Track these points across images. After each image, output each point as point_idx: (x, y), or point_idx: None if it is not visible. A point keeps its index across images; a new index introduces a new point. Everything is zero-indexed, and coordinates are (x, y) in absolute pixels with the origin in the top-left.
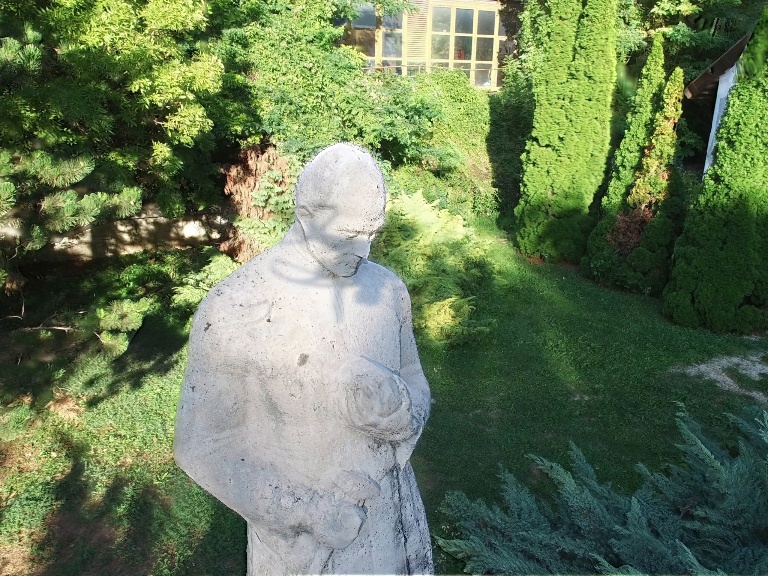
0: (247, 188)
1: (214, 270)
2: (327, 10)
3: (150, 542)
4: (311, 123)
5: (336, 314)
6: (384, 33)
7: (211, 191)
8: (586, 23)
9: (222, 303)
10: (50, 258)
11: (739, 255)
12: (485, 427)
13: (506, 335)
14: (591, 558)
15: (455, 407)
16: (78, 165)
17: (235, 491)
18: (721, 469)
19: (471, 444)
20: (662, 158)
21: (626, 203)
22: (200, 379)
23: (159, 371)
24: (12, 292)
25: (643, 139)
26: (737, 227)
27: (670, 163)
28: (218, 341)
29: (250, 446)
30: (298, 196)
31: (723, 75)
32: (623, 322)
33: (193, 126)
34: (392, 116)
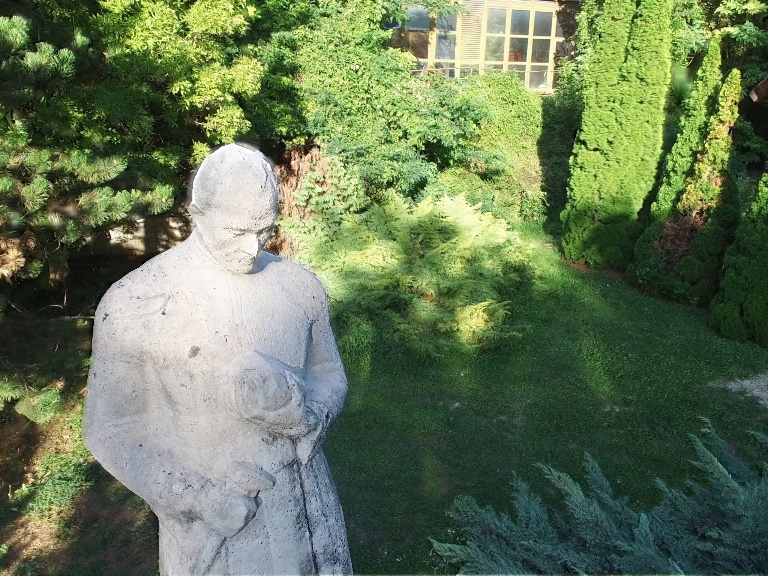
0: (289, 188)
1: None
2: (377, 13)
3: None
4: (355, 124)
5: (232, 308)
6: (438, 35)
7: None
8: (640, 23)
9: (120, 294)
10: (106, 251)
11: None
12: (508, 433)
13: (541, 341)
14: (572, 571)
15: (479, 412)
16: (112, 163)
17: (131, 474)
18: (739, 489)
19: (491, 450)
20: (715, 163)
21: (676, 209)
22: (100, 365)
23: None
24: (55, 282)
25: (696, 143)
26: None
27: (724, 168)
28: (114, 330)
29: (150, 432)
30: None
31: None
32: (666, 333)
33: (231, 126)
34: (437, 118)
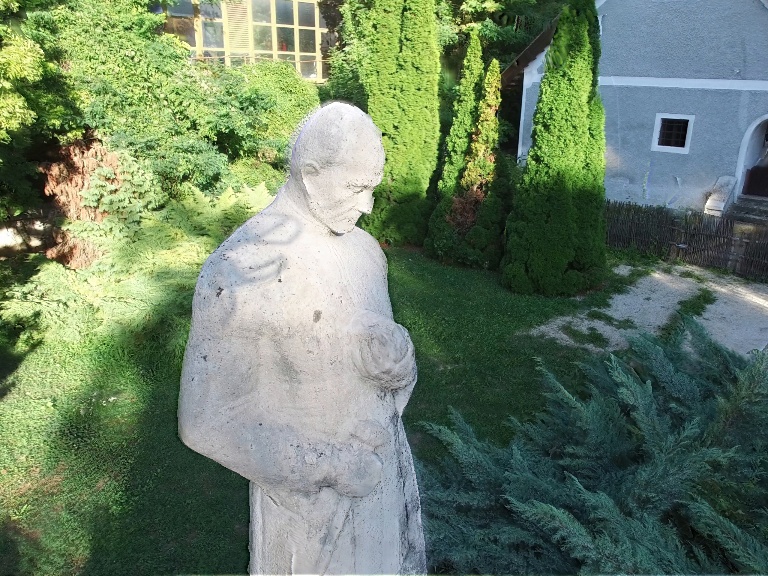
0: (74, 187)
1: (44, 280)
2: None
3: None
4: (140, 115)
5: (339, 269)
6: (203, 22)
7: (27, 193)
8: (409, 16)
9: (231, 265)
10: None
11: (561, 226)
12: None
13: None
14: (502, 498)
15: None
16: None
17: (257, 455)
18: (581, 409)
19: None
20: (488, 142)
21: (460, 185)
22: (213, 346)
23: None
24: None
25: (470, 125)
26: (558, 201)
27: (495, 147)
28: (232, 304)
29: (263, 409)
30: (300, 153)
31: (527, 67)
32: (469, 295)
33: (13, 118)
34: (226, 107)
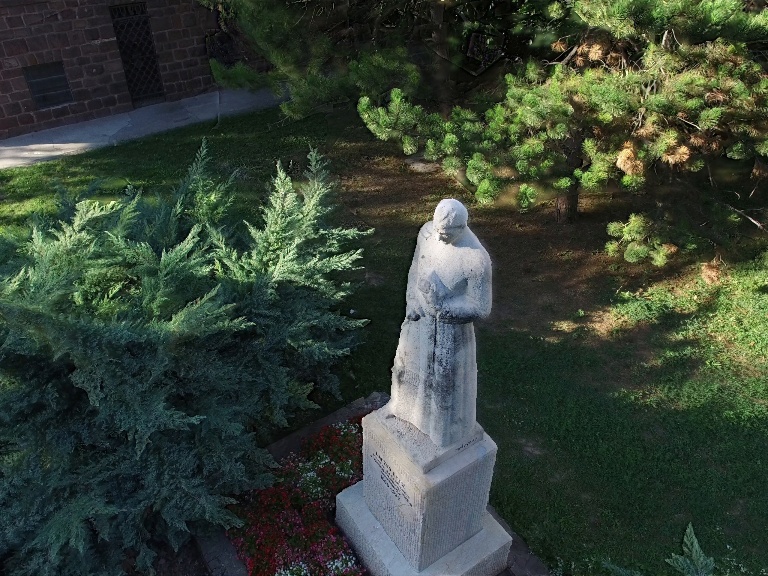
0: None
1: None
2: None
3: (652, 380)
4: None
5: None
6: None
7: None
8: None
9: None
10: None
11: None
12: None
13: None
14: None
15: None
16: None
17: None
18: None
19: None
20: None
21: None
22: None
23: None
24: (755, 176)
25: None
26: None
27: None
28: None
29: None
30: None
31: None
32: None
33: None
34: None
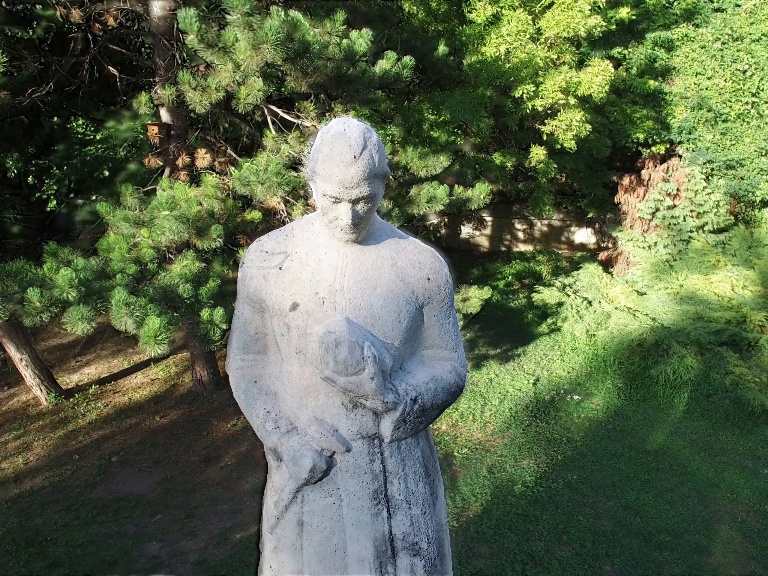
0: (636, 198)
1: (582, 277)
2: None
3: None
4: (730, 133)
5: (336, 275)
6: None
7: (604, 199)
8: None
9: (257, 248)
10: (456, 245)
11: None
12: None
13: None
14: None
15: None
16: (439, 159)
17: None
18: None
19: None
20: None
21: None
22: None
23: (501, 360)
24: None
25: None
26: None
27: None
28: None
29: (268, 374)
30: None
31: None
32: None
33: (569, 130)
34: None
